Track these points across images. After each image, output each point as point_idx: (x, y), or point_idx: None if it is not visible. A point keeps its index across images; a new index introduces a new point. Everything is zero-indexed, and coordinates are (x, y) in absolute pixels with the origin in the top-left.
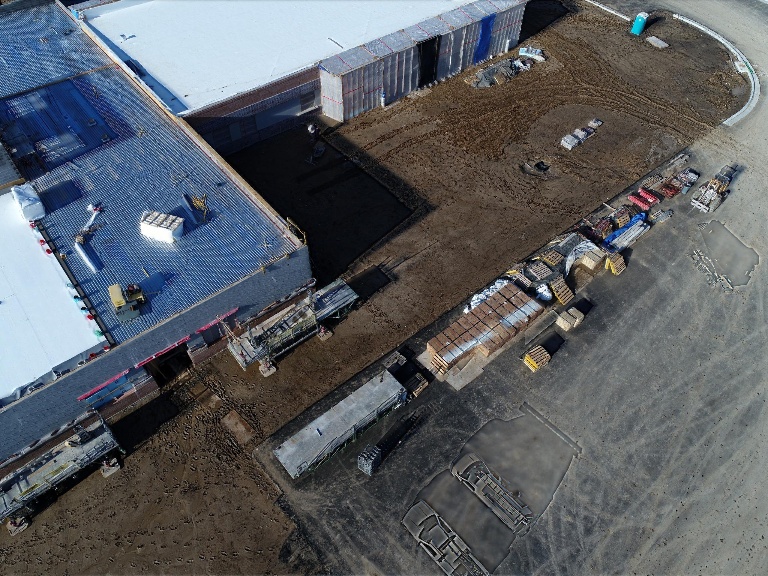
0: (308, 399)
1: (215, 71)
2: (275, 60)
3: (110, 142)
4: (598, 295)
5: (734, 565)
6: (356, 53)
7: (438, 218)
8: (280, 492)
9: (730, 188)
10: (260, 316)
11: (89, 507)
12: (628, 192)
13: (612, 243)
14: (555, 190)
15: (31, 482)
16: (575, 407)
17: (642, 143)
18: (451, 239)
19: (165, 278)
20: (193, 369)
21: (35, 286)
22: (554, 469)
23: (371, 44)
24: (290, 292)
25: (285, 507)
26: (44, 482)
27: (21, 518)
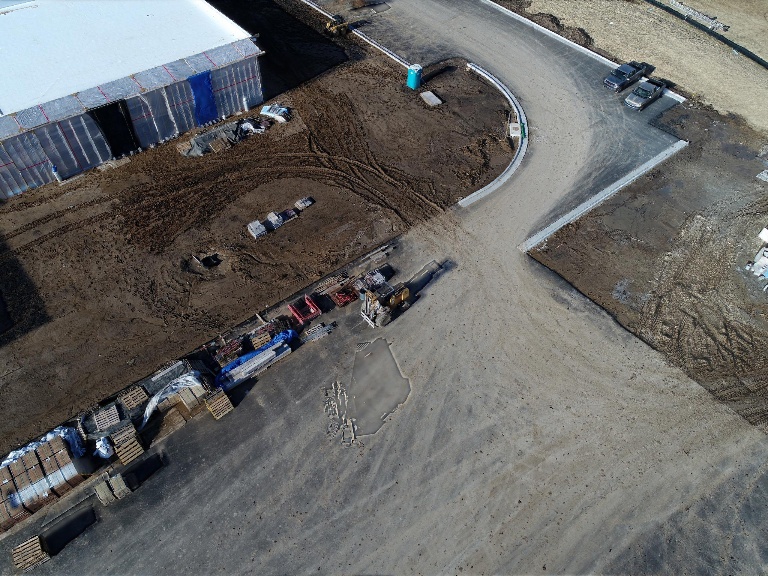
0: None
1: None
2: None
3: None
4: (177, 449)
5: None
6: None
7: (40, 334)
8: None
9: (422, 292)
10: None
11: None
12: (295, 298)
13: (229, 373)
14: (208, 294)
15: None
16: None
17: (348, 230)
18: (39, 365)
19: None
20: None
21: None
22: None
23: (25, 112)
24: None
25: None
26: None
27: None
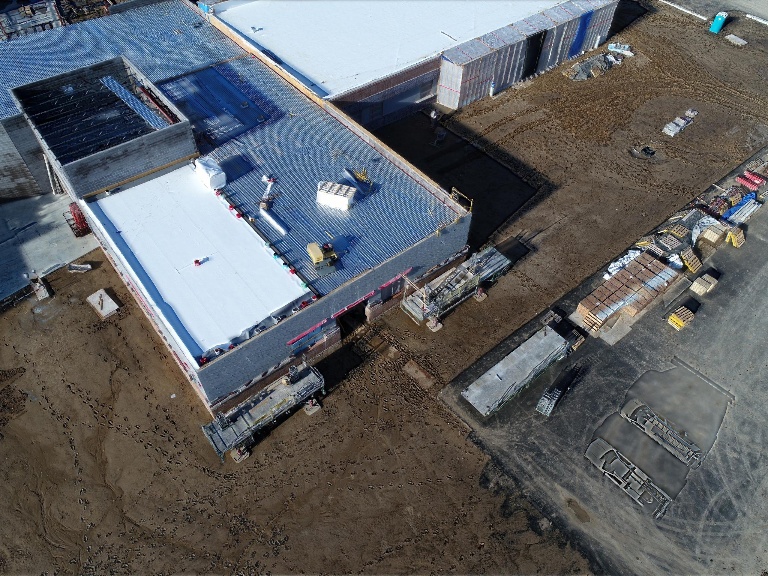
0: (477, 351)
1: (344, 60)
2: (397, 51)
3: (265, 122)
4: (724, 265)
5: None
6: (473, 45)
7: (562, 196)
8: (470, 429)
9: None
10: (424, 278)
11: (300, 440)
12: (734, 175)
13: (729, 219)
14: (665, 172)
15: (254, 415)
16: (721, 361)
17: (738, 131)
18: (578, 214)
19: (348, 240)
20: (367, 324)
21: (235, 245)
22: (713, 413)
23: (485, 37)
24: (448, 257)
25: (477, 442)
26: (270, 413)
27: (242, 448)
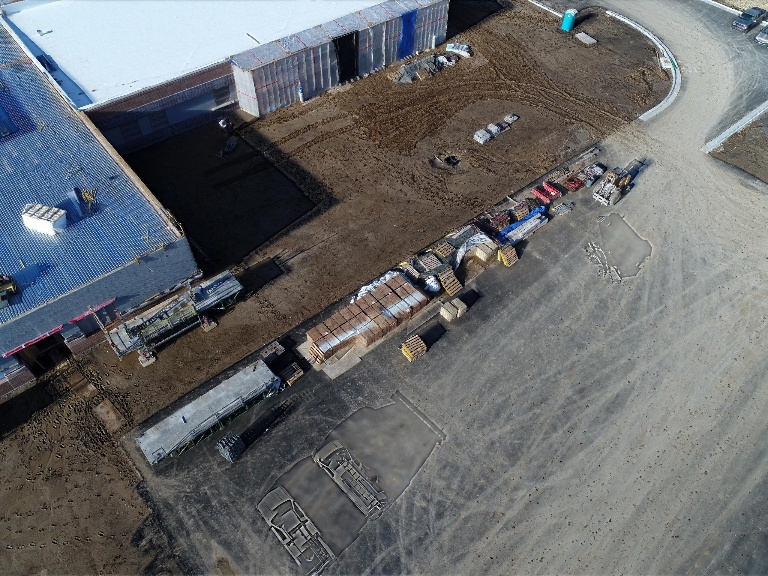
0: (183, 388)
1: (127, 66)
2: (189, 55)
3: (9, 136)
4: (487, 286)
5: (577, 547)
6: (269, 48)
7: (340, 211)
8: (140, 479)
9: (635, 182)
10: (142, 307)
11: None
12: (533, 186)
13: (507, 235)
14: (461, 184)
15: None
16: (446, 395)
17: (555, 138)
18: (350, 232)
19: (41, 269)
20: (73, 359)
21: None
22: (416, 455)
23: (285, 39)
24: (175, 283)
25: (143, 493)
26: None
27: None
